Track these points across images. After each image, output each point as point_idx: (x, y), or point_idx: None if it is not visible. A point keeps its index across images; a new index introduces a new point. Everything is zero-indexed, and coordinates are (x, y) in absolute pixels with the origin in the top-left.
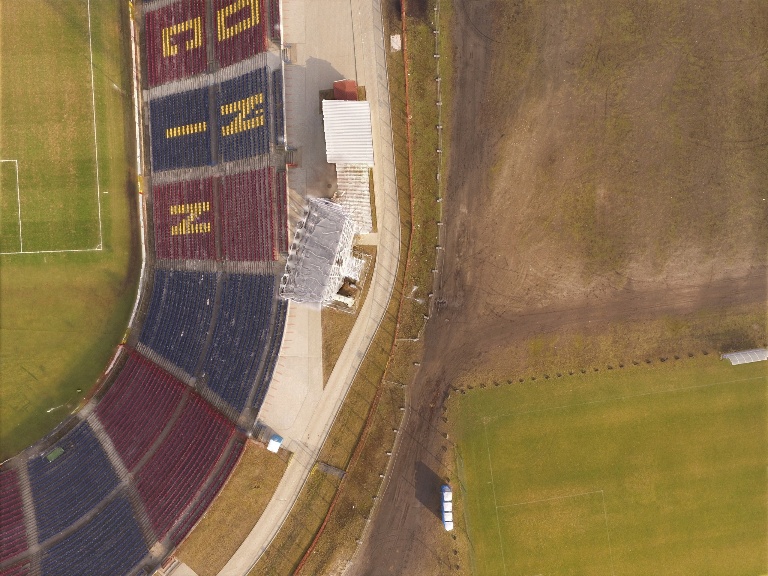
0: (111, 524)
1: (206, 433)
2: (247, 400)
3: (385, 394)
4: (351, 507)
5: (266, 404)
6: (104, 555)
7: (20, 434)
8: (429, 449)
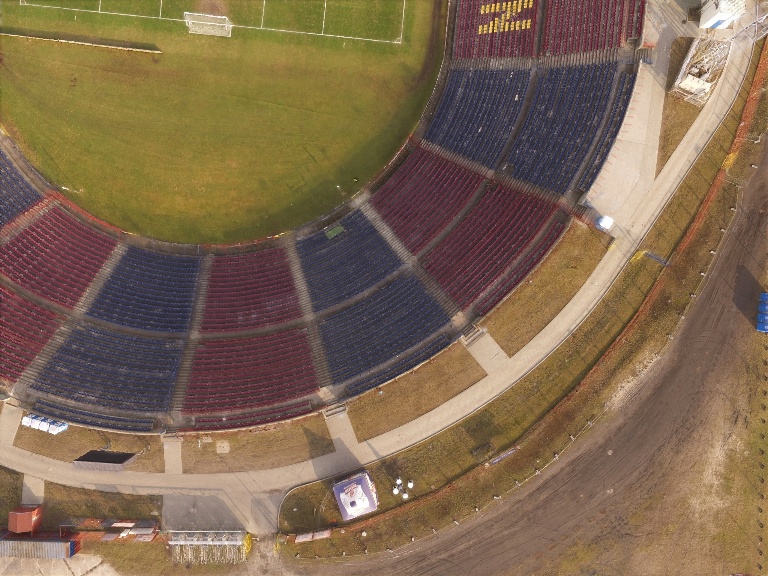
0: (398, 298)
1: (515, 216)
2: (571, 182)
3: (717, 192)
4: (667, 301)
5: (596, 185)
6: (394, 324)
7: (291, 214)
8: (753, 254)
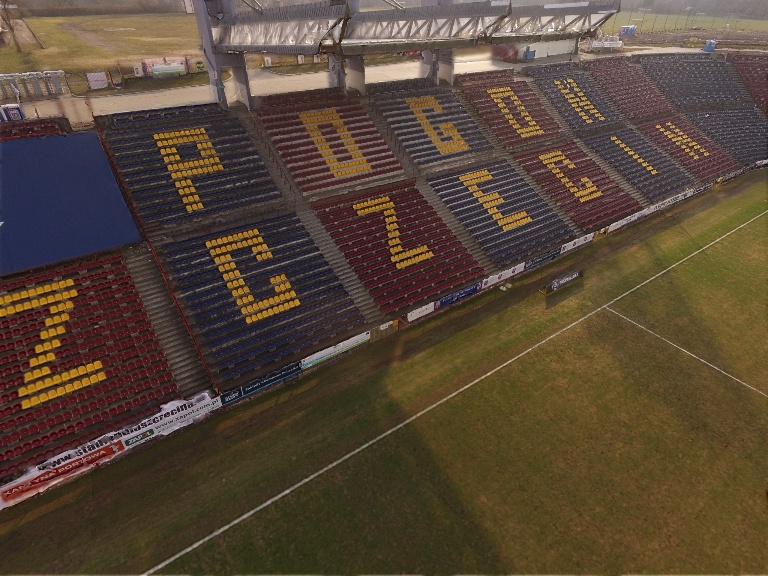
0: None
1: (762, 79)
2: None
3: None
4: None
5: None
6: None
7: None
8: None
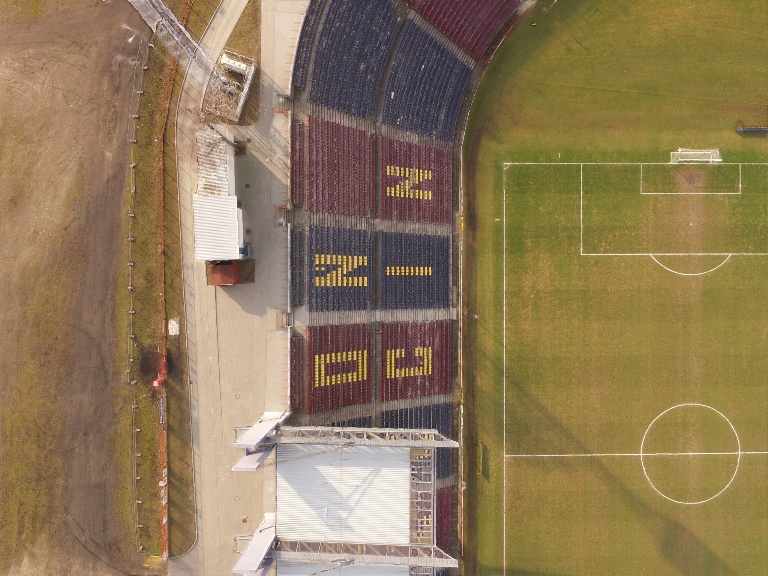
0: None
1: None
2: None
3: None
4: None
5: None
6: None
7: None
8: None
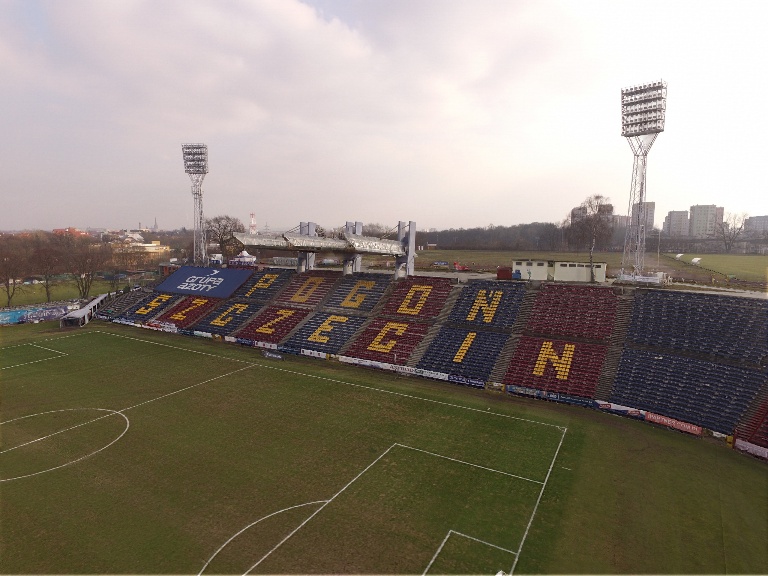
0: None
1: None
2: None
3: None
4: None
5: None
6: None
7: None
8: None
